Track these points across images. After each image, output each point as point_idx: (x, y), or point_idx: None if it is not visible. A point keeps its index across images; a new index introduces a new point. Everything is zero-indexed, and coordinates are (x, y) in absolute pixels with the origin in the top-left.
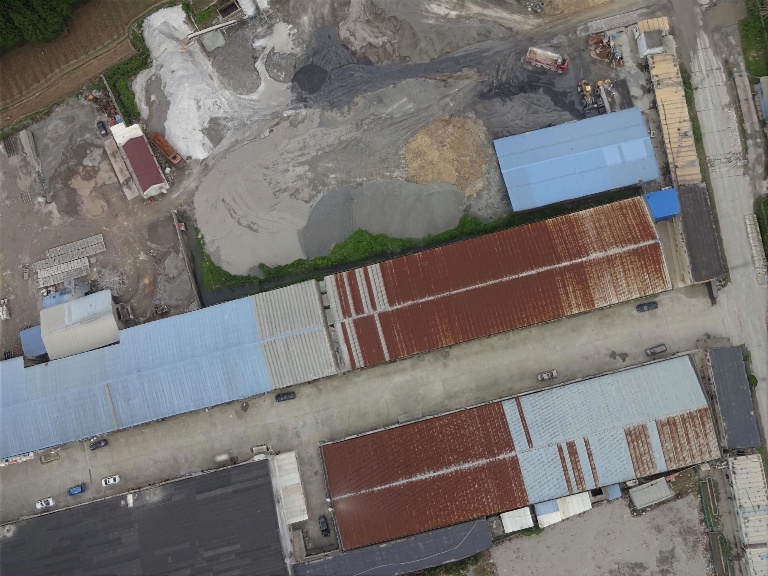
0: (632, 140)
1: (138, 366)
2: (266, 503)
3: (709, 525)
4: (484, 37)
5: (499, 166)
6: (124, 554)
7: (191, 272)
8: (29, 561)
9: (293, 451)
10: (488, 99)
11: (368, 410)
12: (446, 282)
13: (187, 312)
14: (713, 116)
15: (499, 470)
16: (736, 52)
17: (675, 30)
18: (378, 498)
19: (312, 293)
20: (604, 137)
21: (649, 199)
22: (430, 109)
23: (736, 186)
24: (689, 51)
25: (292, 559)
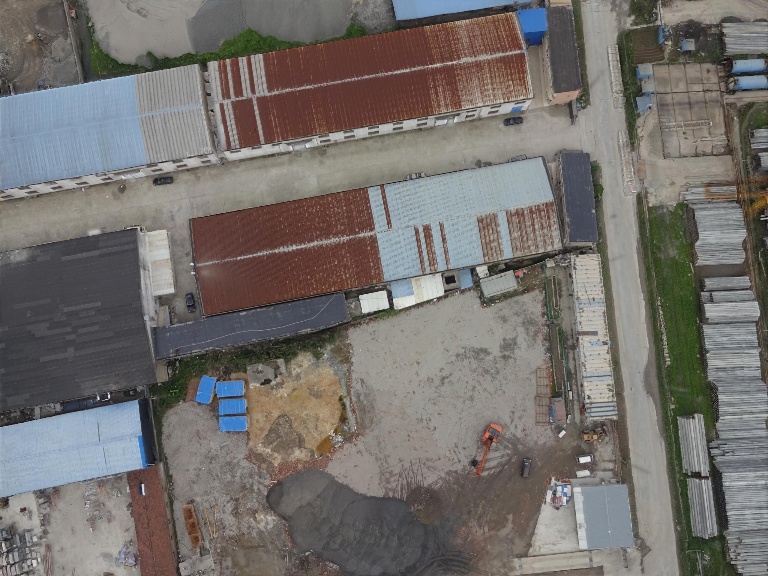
0: None
1: (12, 131)
2: (131, 267)
3: (550, 317)
4: None
5: None
6: None
7: (78, 57)
8: None
9: (165, 229)
10: None
11: (243, 199)
12: (324, 74)
13: (68, 86)
14: None
15: (358, 247)
16: None
17: None
18: (241, 267)
19: (194, 76)
20: None
21: (520, 15)
22: None
23: (603, 20)
24: None
25: (153, 323)
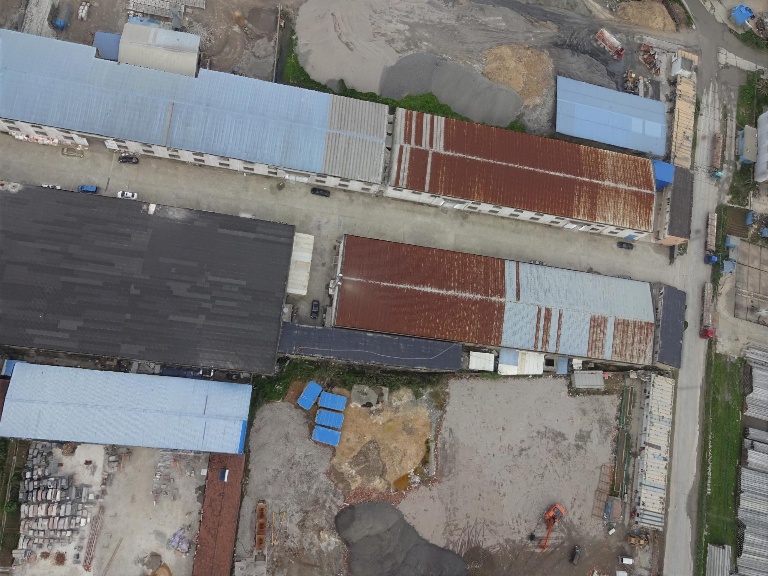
0: (654, 122)
1: (209, 101)
2: (282, 259)
3: (622, 422)
4: (570, 7)
5: (556, 95)
6: (129, 250)
7: (276, 60)
8: (26, 220)
9: None
10: (561, 48)
11: (387, 232)
12: (493, 153)
13: (268, 82)
14: (707, 138)
15: (487, 308)
16: (733, 104)
17: (699, 70)
18: (382, 292)
19: (383, 114)
20: (636, 111)
21: (655, 164)
22: (516, 34)
23: (708, 191)
24: (704, 88)
25: (284, 317)
